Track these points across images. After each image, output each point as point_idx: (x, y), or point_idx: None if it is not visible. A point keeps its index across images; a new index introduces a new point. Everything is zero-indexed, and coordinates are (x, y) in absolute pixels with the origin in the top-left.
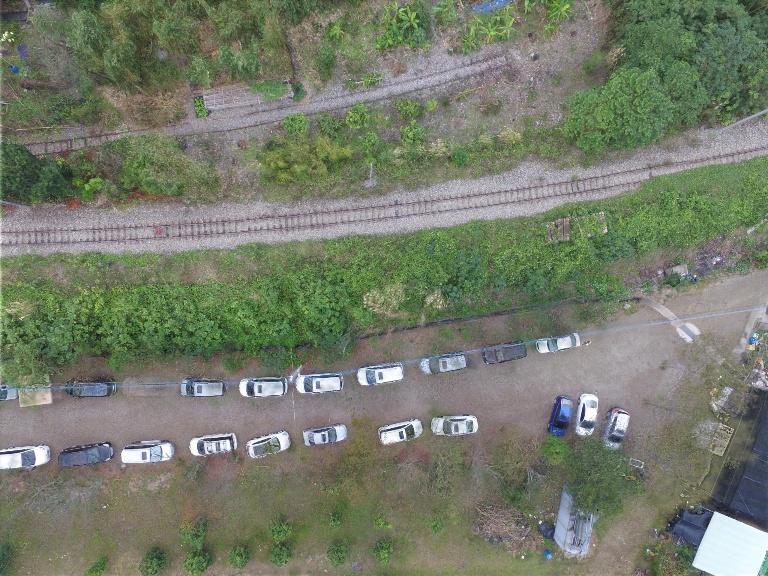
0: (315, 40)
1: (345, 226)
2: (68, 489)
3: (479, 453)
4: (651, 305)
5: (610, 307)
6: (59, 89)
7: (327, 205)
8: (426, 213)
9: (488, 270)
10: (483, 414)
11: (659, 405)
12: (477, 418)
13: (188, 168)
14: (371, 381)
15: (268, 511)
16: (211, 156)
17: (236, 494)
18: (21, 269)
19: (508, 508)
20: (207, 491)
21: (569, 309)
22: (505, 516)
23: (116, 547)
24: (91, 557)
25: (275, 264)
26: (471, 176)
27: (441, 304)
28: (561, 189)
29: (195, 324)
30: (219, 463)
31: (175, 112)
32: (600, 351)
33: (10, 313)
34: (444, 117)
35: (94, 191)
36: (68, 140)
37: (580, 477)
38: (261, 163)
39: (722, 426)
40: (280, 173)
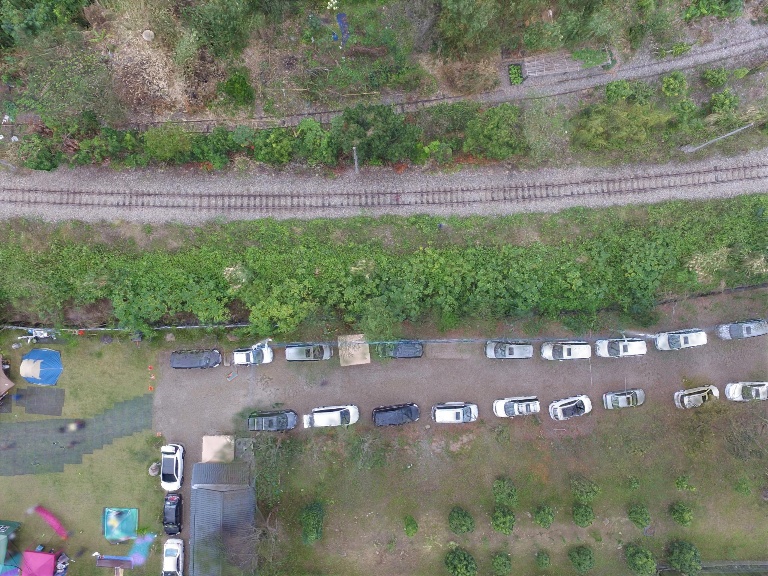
0: (625, 9)
1: (666, 191)
2: None
3: None
4: None
5: None
6: (376, 56)
7: (648, 170)
8: (746, 179)
9: None
10: None
11: None
12: None
13: None
14: (674, 346)
15: (564, 474)
16: (521, 123)
17: (534, 456)
18: (352, 230)
19: None
20: (506, 453)
21: None
22: None
23: (418, 506)
24: (395, 516)
25: (597, 228)
26: None
27: (764, 268)
28: None
29: (523, 285)
30: (518, 425)
31: (494, 79)
32: None
33: None
34: (743, 87)
35: None
36: None
37: None
38: (567, 130)
39: None
40: (596, 139)
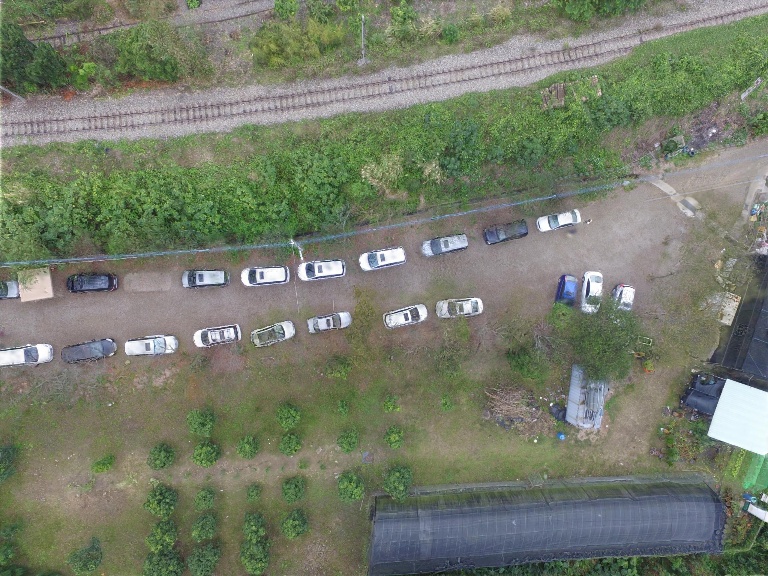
0: None
1: (340, 104)
2: (72, 389)
3: (486, 336)
4: (650, 181)
5: (609, 183)
6: None
7: (321, 84)
8: (420, 87)
9: (485, 142)
10: (487, 297)
11: (664, 281)
12: (482, 300)
13: (181, 61)
14: (373, 264)
15: (275, 403)
16: (204, 47)
17: (242, 387)
18: (18, 160)
19: (518, 390)
20: (213, 385)
21: (568, 188)
22: (515, 397)
23: (123, 446)
24: (98, 457)
25: (272, 145)
26: (463, 50)
27: (439, 175)
28: (553, 58)
29: (194, 206)
30: (224, 356)
31: (166, 2)
32: (601, 229)
33: (8, 201)
34: (433, 2)
35: (88, 78)
36: (61, 36)
37: (589, 356)
38: None
39: (729, 294)
40: (273, 58)
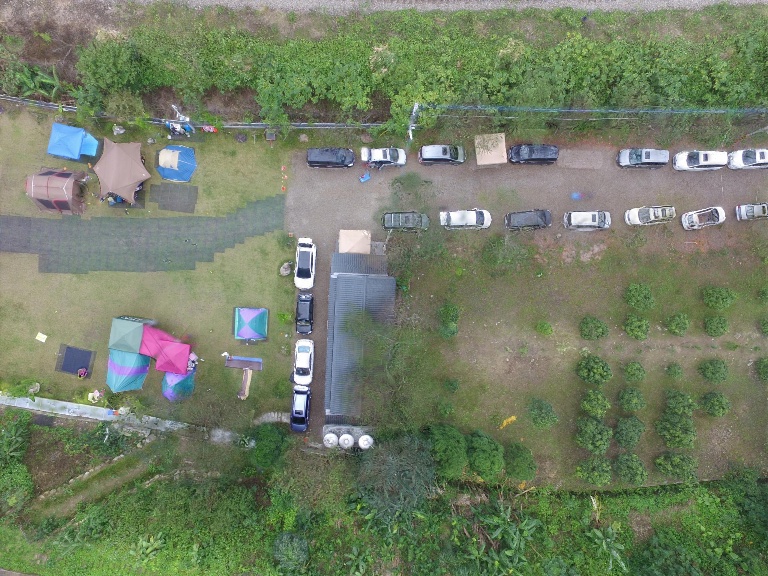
0: None
1: None
2: None
3: None
4: None
5: None
6: None
7: None
8: None
9: None
10: None
11: None
12: None
13: None
14: None
15: (695, 288)
16: None
17: (664, 269)
18: (495, 23)
19: None
20: (636, 265)
21: None
22: None
23: (548, 317)
24: (524, 325)
25: (740, 26)
26: None
27: None
28: None
29: (668, 79)
30: (649, 237)
31: None
32: None
33: None
34: None
35: None
36: None
37: None
38: None
39: None
40: None
